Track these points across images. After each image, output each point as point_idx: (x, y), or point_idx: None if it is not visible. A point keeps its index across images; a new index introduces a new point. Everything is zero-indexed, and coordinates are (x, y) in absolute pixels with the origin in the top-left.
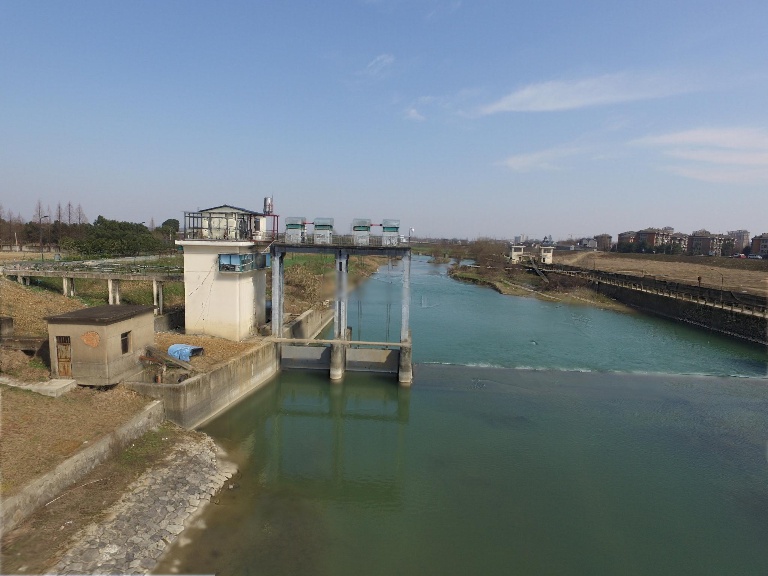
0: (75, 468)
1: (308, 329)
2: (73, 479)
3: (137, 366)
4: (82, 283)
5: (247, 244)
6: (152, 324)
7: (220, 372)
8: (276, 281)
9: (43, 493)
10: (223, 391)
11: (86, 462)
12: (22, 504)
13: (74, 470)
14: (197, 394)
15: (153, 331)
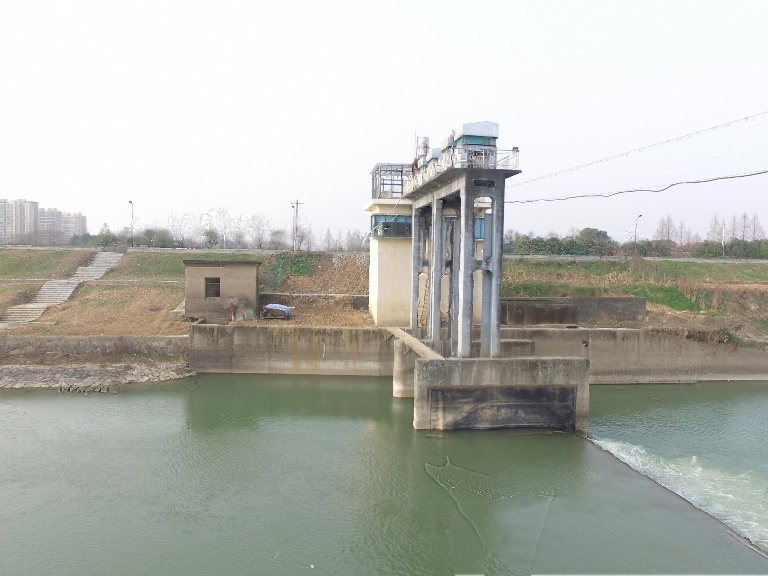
0: (80, 344)
1: (594, 356)
2: (76, 350)
3: (227, 312)
4: None
5: (392, 202)
6: (254, 279)
7: (253, 331)
8: (412, 250)
9: (51, 346)
10: (258, 354)
11: (90, 345)
12: (35, 344)
13: (78, 345)
14: (210, 340)
15: (255, 286)
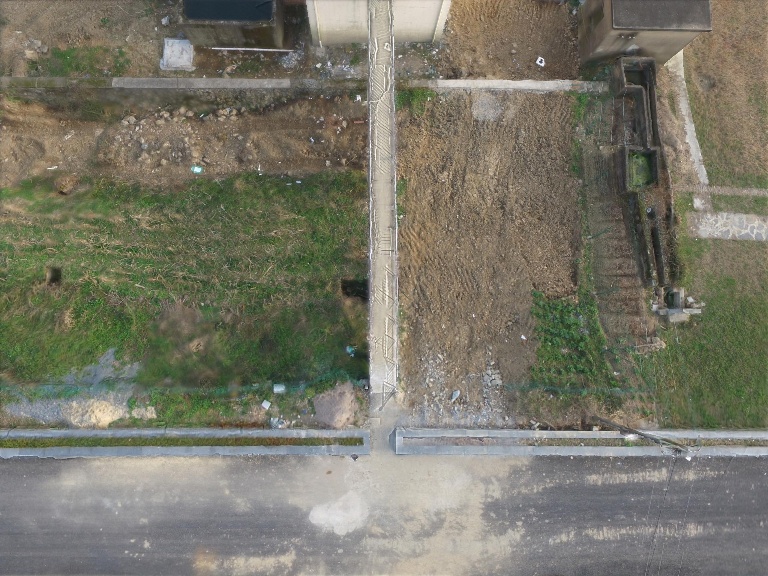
0: None
1: None
2: None
3: None
4: (253, 330)
5: None
6: None
7: None
8: None
9: None
10: None
11: None
12: None
13: None
14: None
15: None
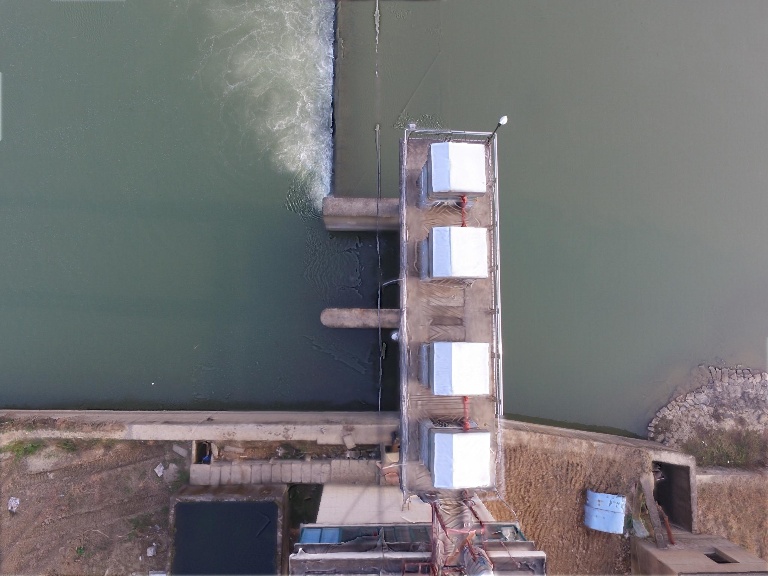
0: None
1: None
2: None
3: None
4: None
5: (505, 554)
6: None
7: None
8: None
9: None
10: None
11: None
12: None
13: None
14: None
15: None
